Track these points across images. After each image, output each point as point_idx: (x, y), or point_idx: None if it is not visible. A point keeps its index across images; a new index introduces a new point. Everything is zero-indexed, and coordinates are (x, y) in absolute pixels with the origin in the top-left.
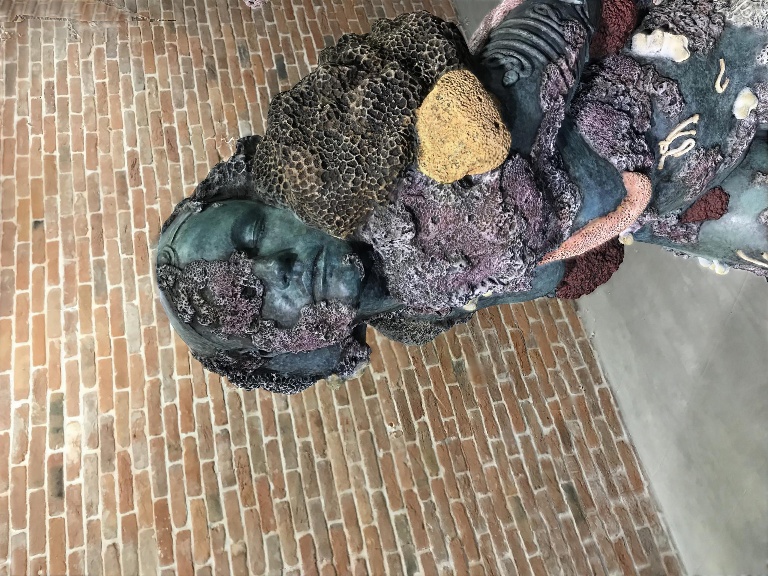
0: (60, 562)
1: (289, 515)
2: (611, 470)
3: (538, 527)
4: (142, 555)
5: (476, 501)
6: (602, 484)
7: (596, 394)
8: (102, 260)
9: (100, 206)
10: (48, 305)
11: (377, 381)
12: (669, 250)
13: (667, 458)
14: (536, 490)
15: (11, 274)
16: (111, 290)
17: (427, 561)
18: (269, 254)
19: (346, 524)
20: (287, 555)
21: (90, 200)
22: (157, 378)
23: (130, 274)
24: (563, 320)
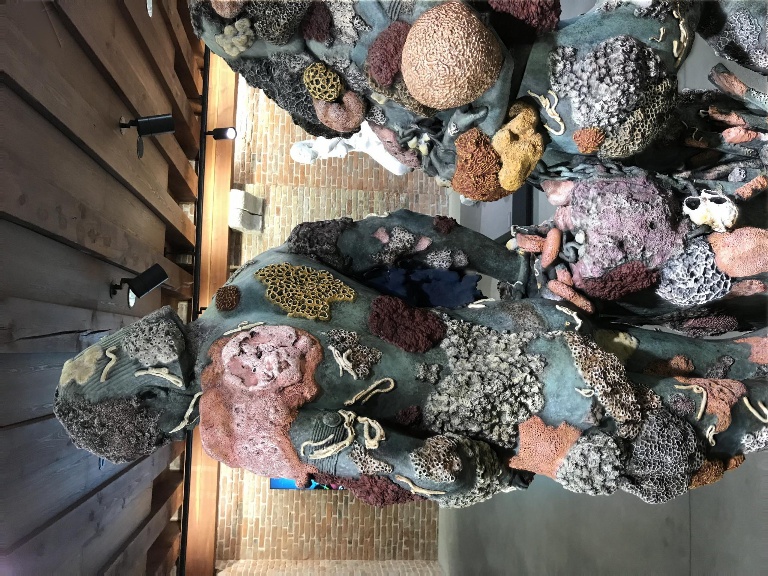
0: None
1: None
2: None
3: None
4: None
5: None
6: None
7: None
8: None
9: None
10: None
11: None
12: (599, 8)
13: None
14: None
15: None
16: None
17: None
18: None
19: None
20: None
21: None
22: None
23: None
24: None
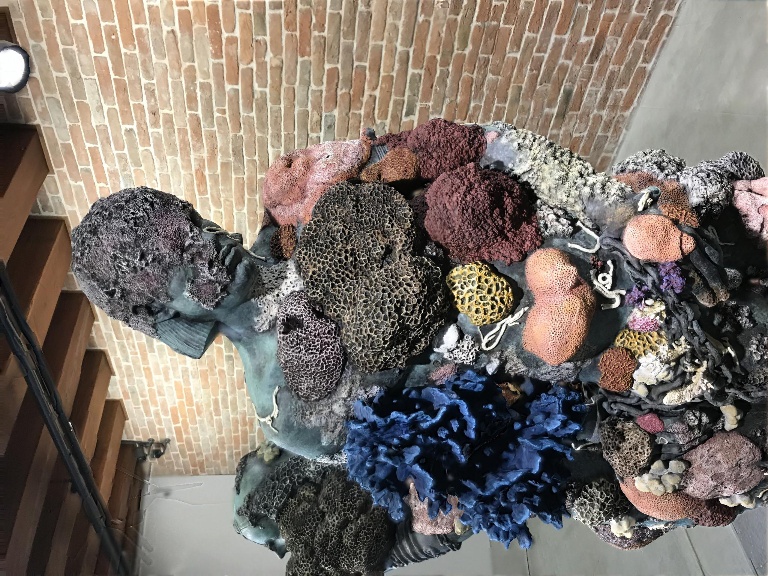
0: (129, 33)
1: (323, 49)
2: (615, 86)
3: (523, 112)
4: (197, 46)
5: (485, 79)
6: (599, 95)
7: (657, 19)
8: None
9: None
10: None
11: None
12: None
13: (659, 113)
14: (540, 85)
15: None
16: None
17: (424, 110)
18: (278, 547)
19: (369, 68)
20: (315, 78)
21: None
22: None
23: None
24: None
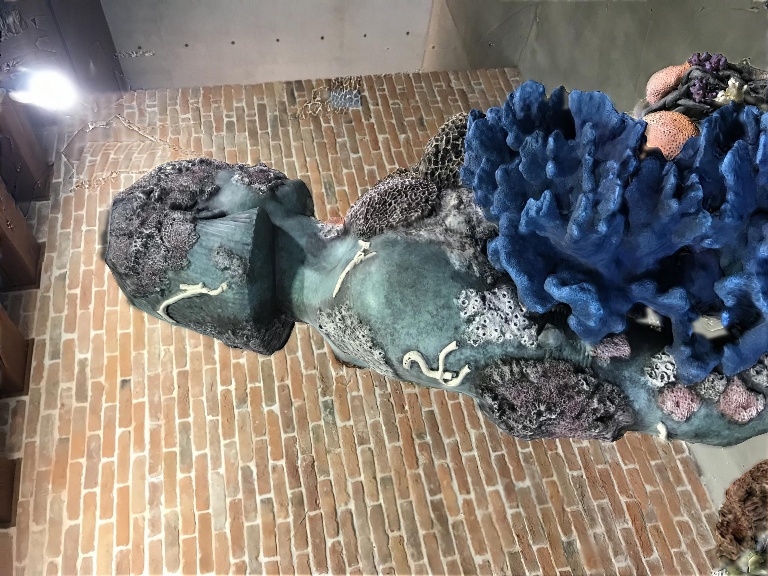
0: None
1: None
2: None
3: None
4: None
5: None
6: None
7: None
8: (188, 422)
9: (186, 361)
10: (133, 475)
11: (479, 566)
12: None
13: None
14: None
15: (97, 440)
16: (196, 457)
17: None
18: None
19: None
20: None
21: (177, 355)
22: (243, 560)
23: (216, 438)
24: (685, 488)
